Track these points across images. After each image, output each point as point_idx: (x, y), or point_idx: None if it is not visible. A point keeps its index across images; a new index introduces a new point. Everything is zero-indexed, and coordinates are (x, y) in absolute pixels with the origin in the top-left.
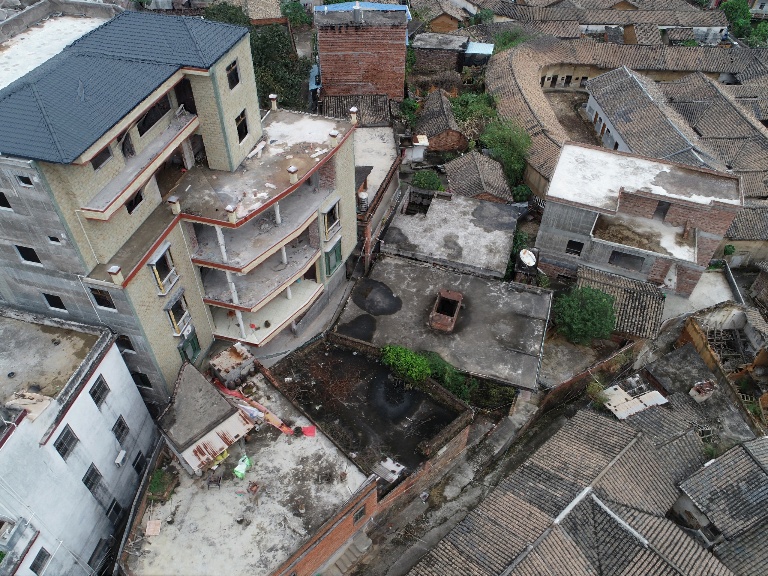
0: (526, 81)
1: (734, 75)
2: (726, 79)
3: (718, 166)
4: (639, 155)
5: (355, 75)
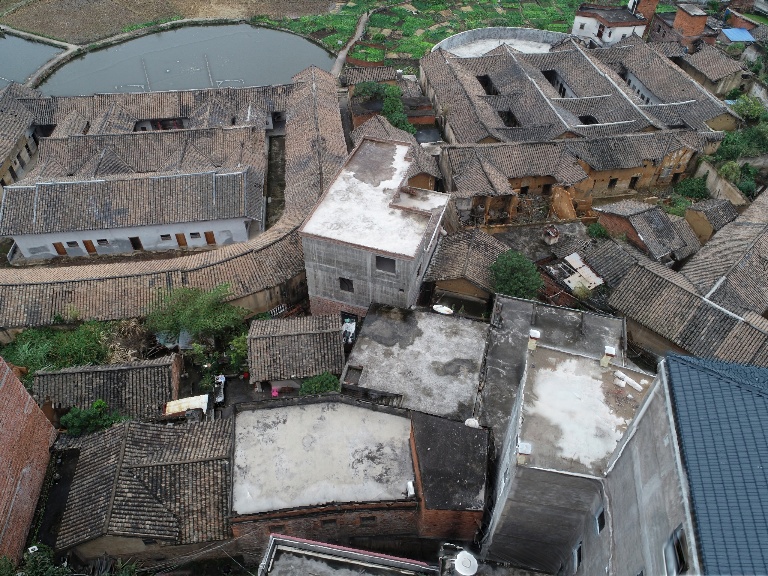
0: (23, 277)
1: (34, 124)
2: (29, 133)
3: (234, 169)
4: (330, 184)
5: (6, 489)
